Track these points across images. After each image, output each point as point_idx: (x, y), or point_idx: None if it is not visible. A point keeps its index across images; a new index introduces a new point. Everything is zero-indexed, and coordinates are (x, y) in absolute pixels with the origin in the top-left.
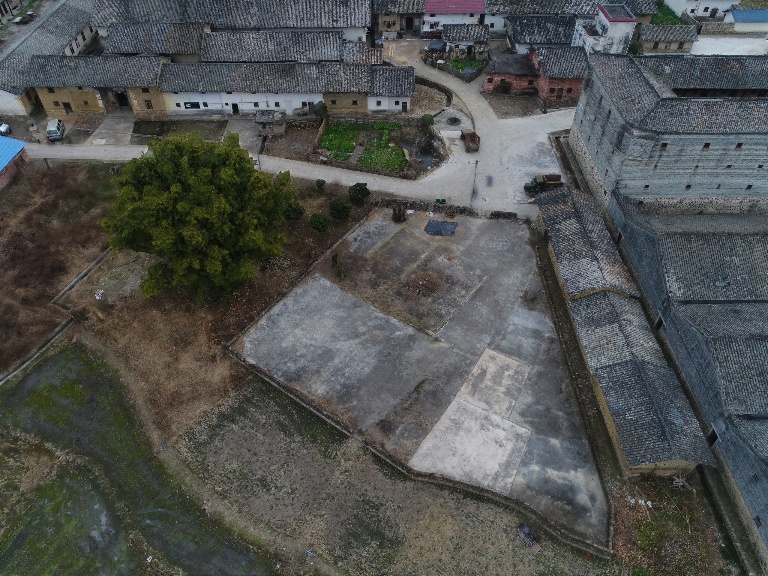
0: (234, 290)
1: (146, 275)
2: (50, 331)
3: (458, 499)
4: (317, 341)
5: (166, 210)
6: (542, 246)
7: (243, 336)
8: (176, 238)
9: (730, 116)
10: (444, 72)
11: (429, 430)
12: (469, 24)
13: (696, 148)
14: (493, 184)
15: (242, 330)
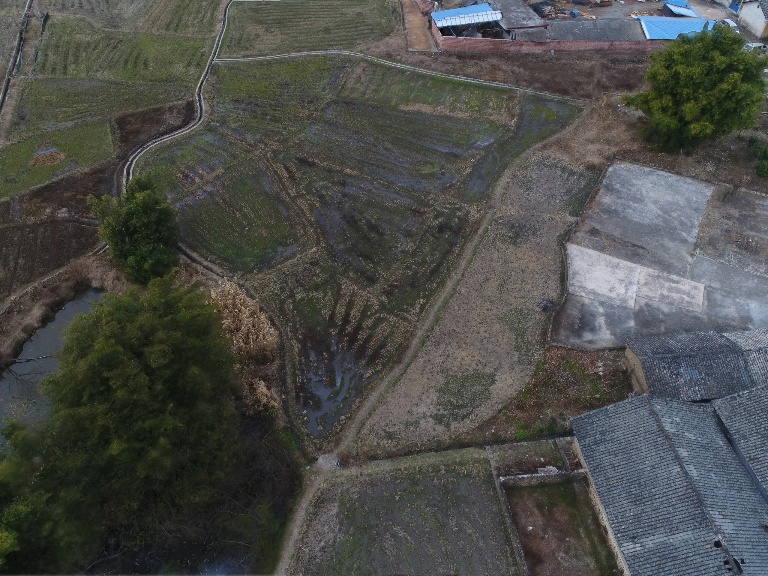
0: (666, 152)
1: None
2: (584, 97)
3: (557, 271)
4: (647, 194)
5: (672, 57)
6: None
7: (628, 163)
8: None
9: None
10: None
11: (603, 252)
12: None
13: None
14: None
15: (633, 161)
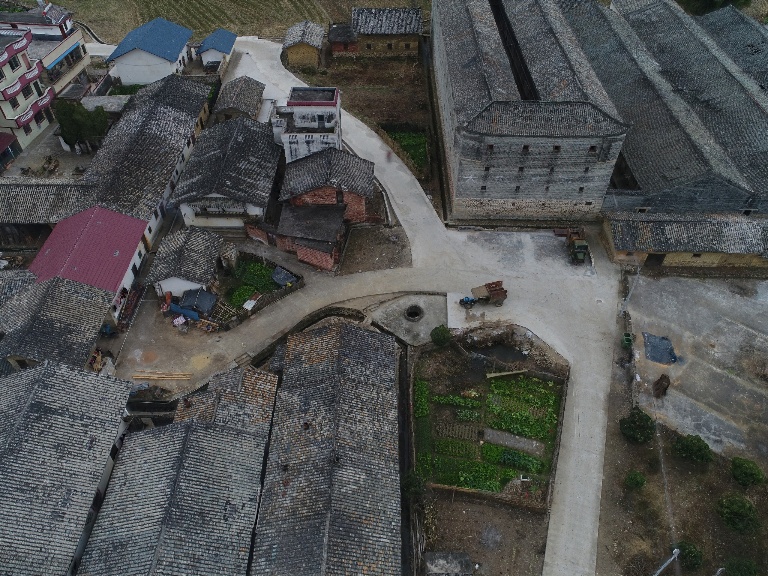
0: None
1: None
2: None
3: None
4: None
5: None
6: (659, 269)
7: None
8: None
9: None
10: (265, 309)
11: None
12: (175, 246)
13: None
14: (566, 290)
15: None
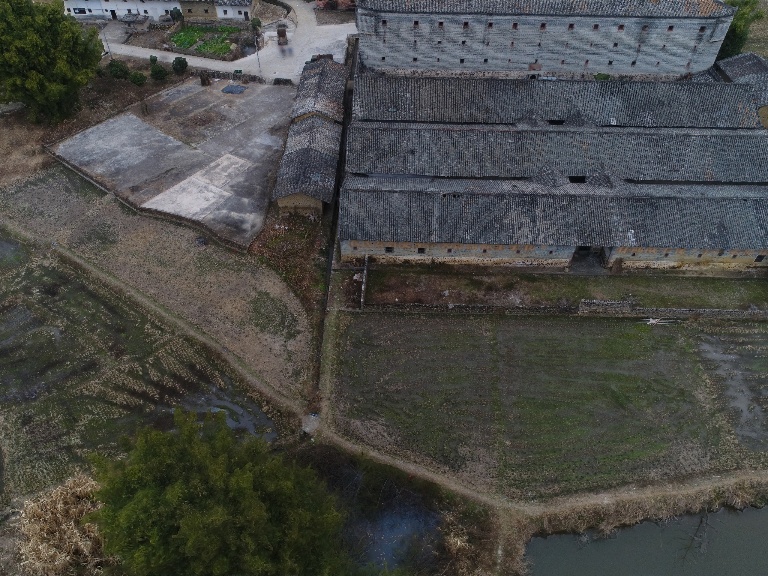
0: (65, 119)
1: (6, 109)
2: None
3: (165, 225)
4: (110, 146)
5: None
6: None
7: (60, 143)
8: (3, 61)
9: (431, 0)
10: None
11: (163, 191)
12: None
13: (409, 25)
14: (287, 64)
15: (60, 139)
